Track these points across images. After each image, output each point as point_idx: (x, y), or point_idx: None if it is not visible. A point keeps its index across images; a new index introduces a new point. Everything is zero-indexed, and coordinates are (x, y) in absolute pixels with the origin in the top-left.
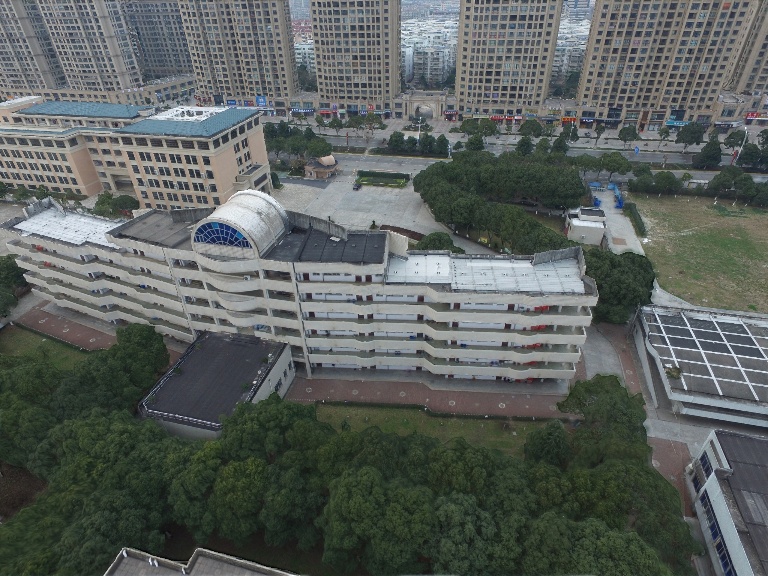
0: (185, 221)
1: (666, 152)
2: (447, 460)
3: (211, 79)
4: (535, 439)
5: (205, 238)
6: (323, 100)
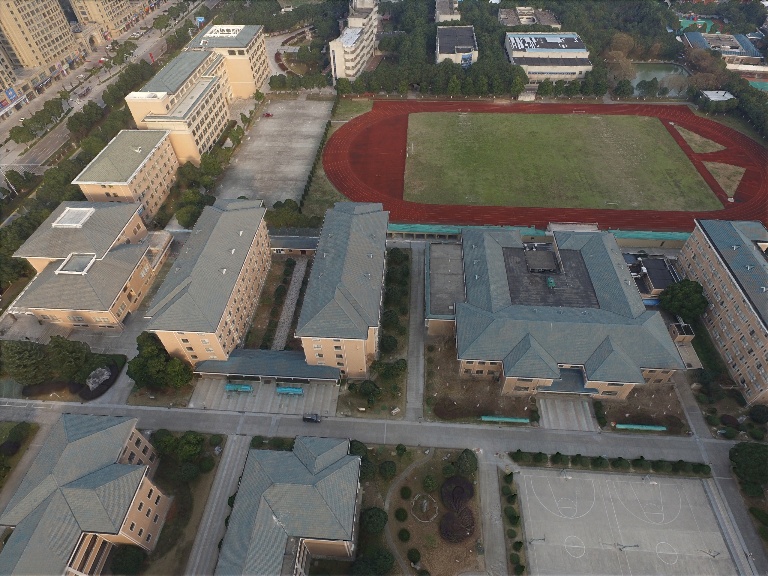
0: None
1: None
2: None
3: None
4: (395, 13)
5: (373, 2)
6: (49, 65)
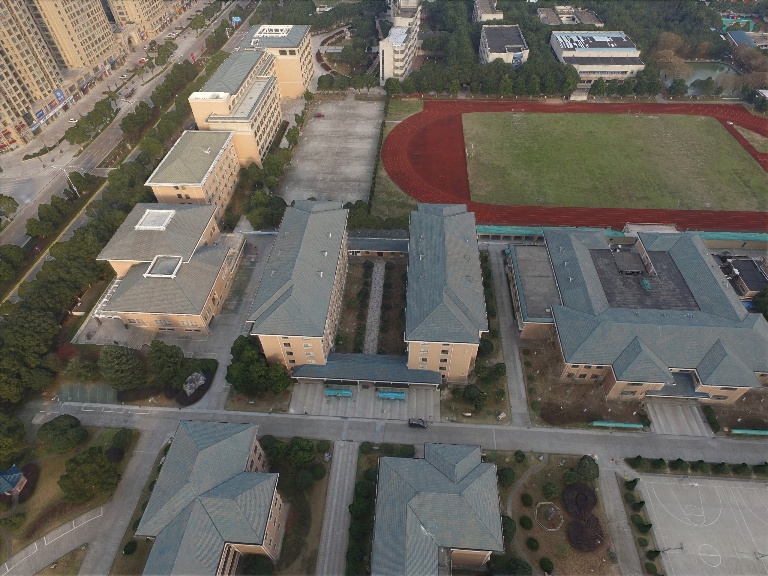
0: None
1: (234, 2)
2: (451, 4)
3: (5, 101)
4: None
5: None
6: (93, 65)
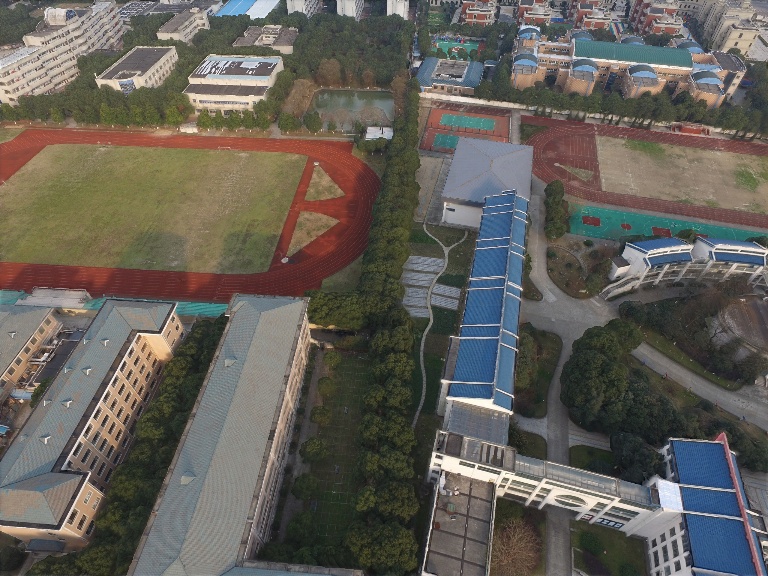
0: (39, 31)
1: None
2: None
3: None
4: None
5: None
6: None
